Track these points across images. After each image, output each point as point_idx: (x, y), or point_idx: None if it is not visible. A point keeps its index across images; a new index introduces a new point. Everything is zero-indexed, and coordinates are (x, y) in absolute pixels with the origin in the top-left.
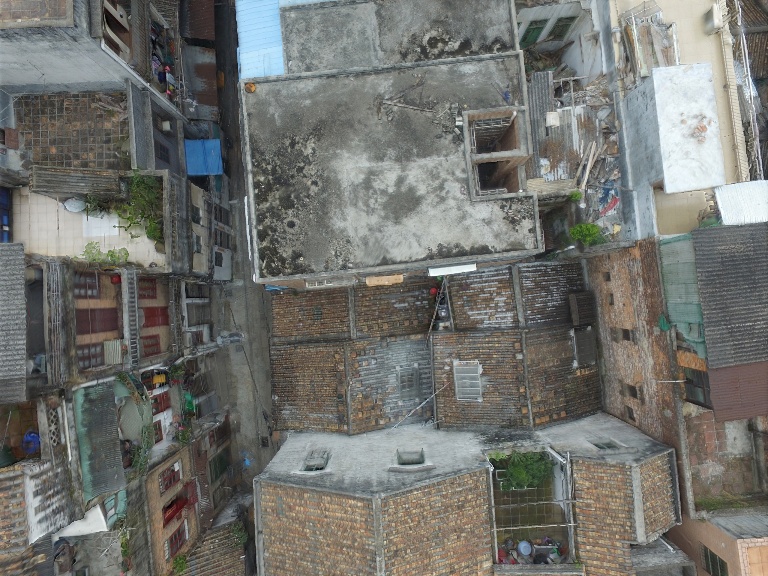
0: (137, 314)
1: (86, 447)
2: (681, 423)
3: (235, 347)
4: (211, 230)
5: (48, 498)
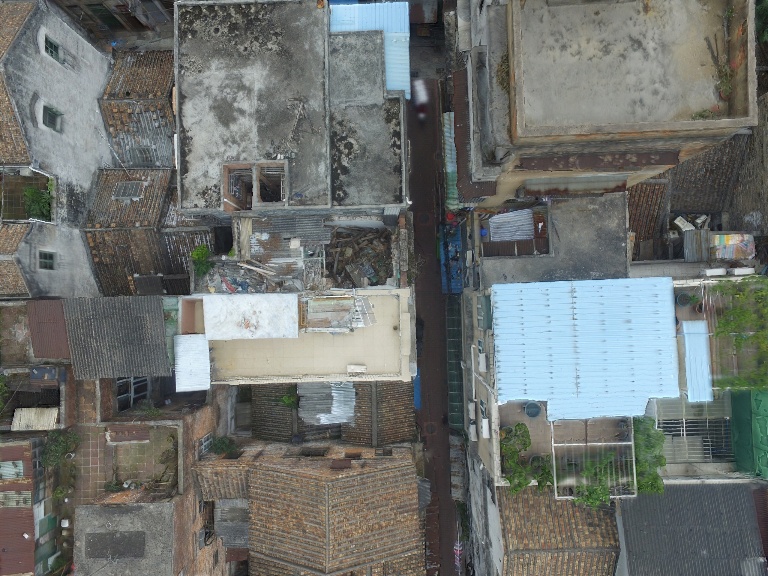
0: None
1: None
2: None
3: None
4: None
5: None
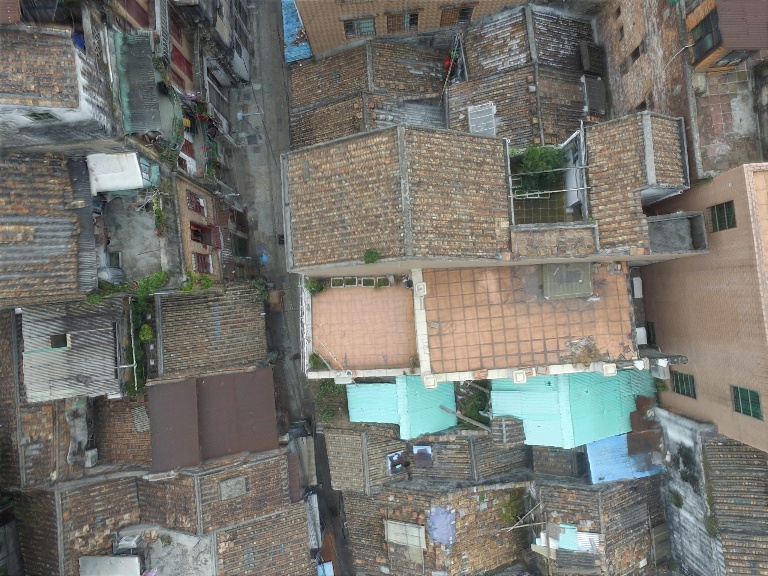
0: (167, 20)
1: (125, 86)
2: (690, 89)
3: (253, 149)
4: (232, 11)
5: (94, 92)
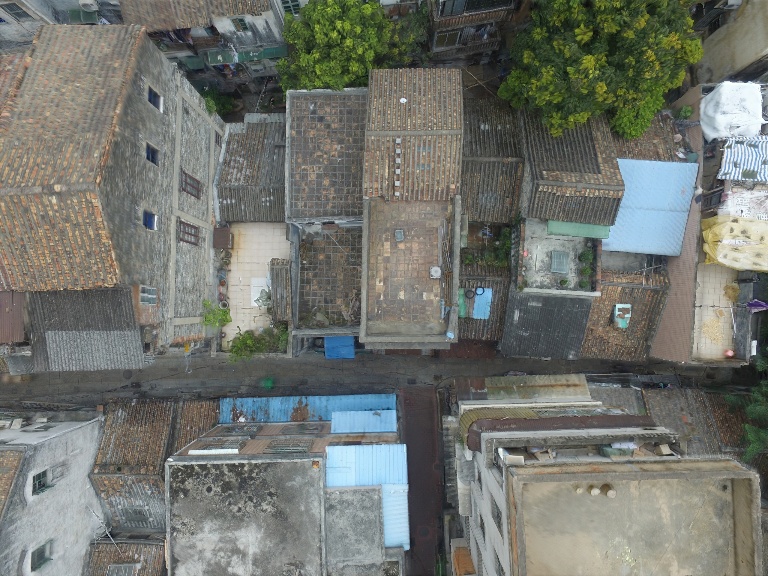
0: None
1: None
2: None
3: None
4: None
5: None
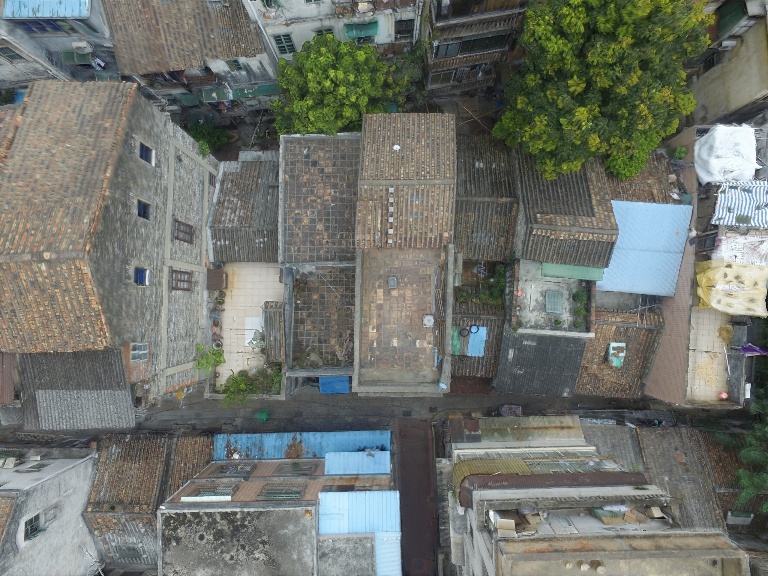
0: None
1: None
2: None
3: None
4: None
5: None
